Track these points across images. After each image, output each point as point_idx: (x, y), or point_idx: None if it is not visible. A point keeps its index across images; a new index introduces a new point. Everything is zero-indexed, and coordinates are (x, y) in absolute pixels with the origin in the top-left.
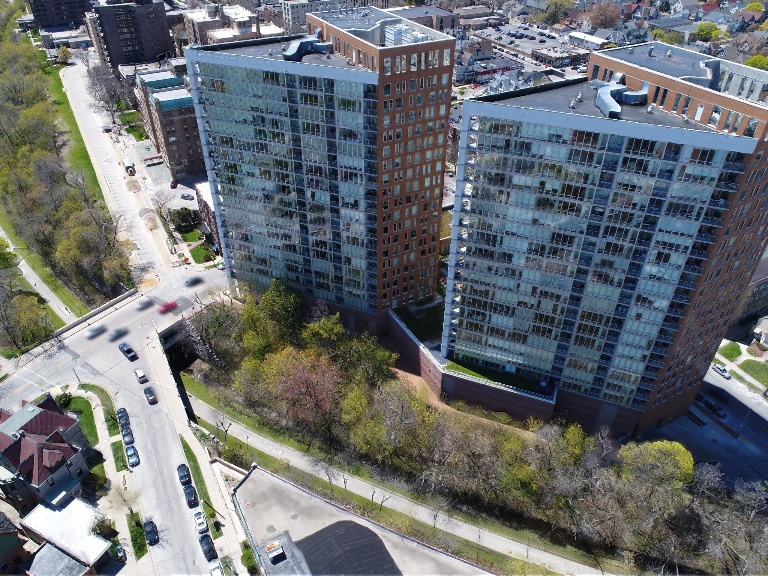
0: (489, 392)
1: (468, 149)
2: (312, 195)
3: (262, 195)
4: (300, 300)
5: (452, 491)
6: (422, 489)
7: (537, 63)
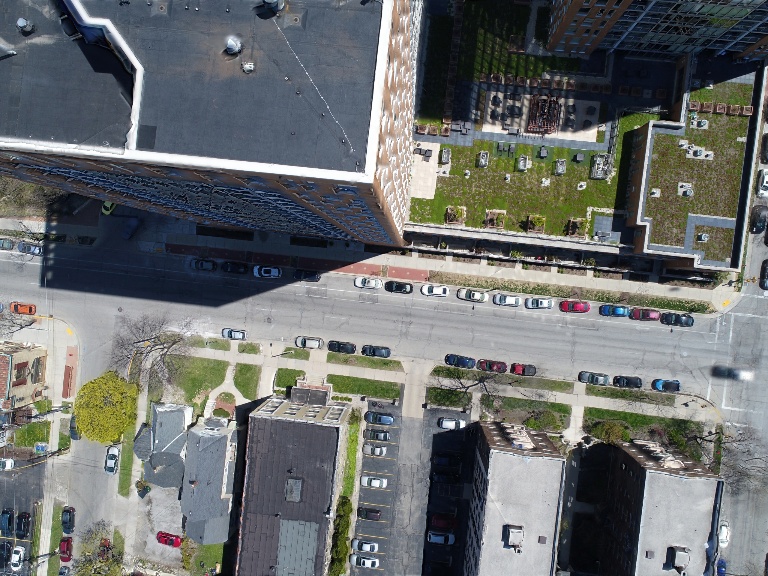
0: None
1: None
2: None
3: None
4: None
5: None
6: None
7: None
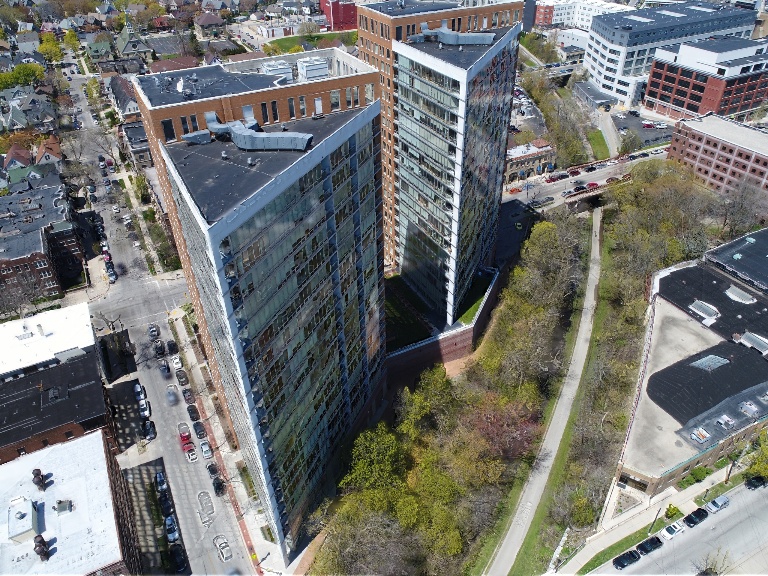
0: None
1: None
2: None
3: (307, 364)
4: None
5: (543, 372)
6: (545, 391)
7: None
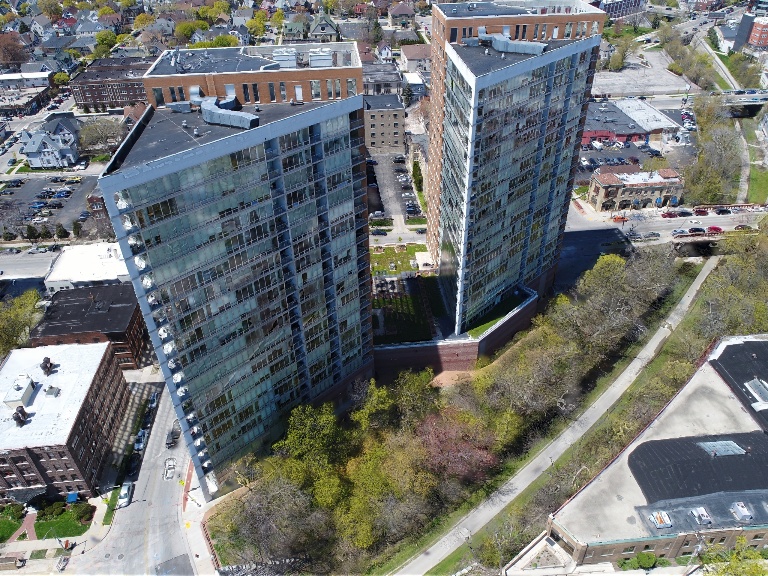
0: (505, 327)
1: (478, 123)
2: (303, 279)
3: (241, 325)
4: (332, 403)
5: (552, 409)
6: (544, 428)
7: (28, 114)
